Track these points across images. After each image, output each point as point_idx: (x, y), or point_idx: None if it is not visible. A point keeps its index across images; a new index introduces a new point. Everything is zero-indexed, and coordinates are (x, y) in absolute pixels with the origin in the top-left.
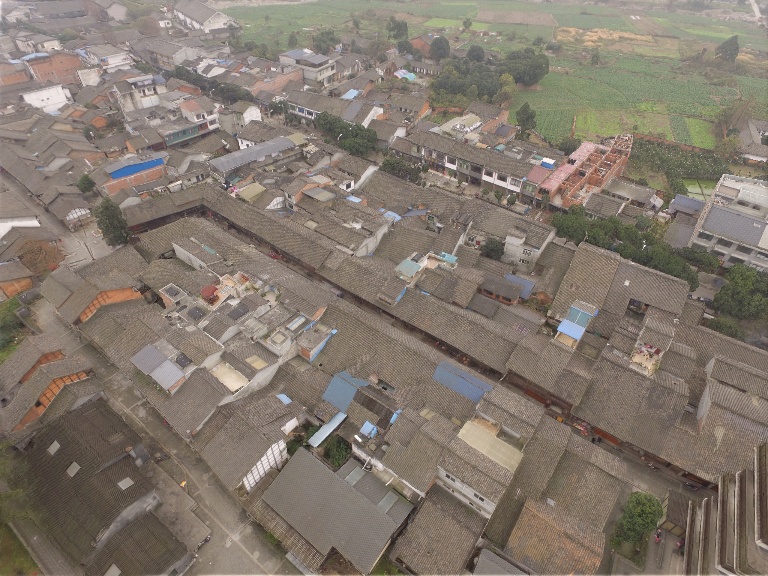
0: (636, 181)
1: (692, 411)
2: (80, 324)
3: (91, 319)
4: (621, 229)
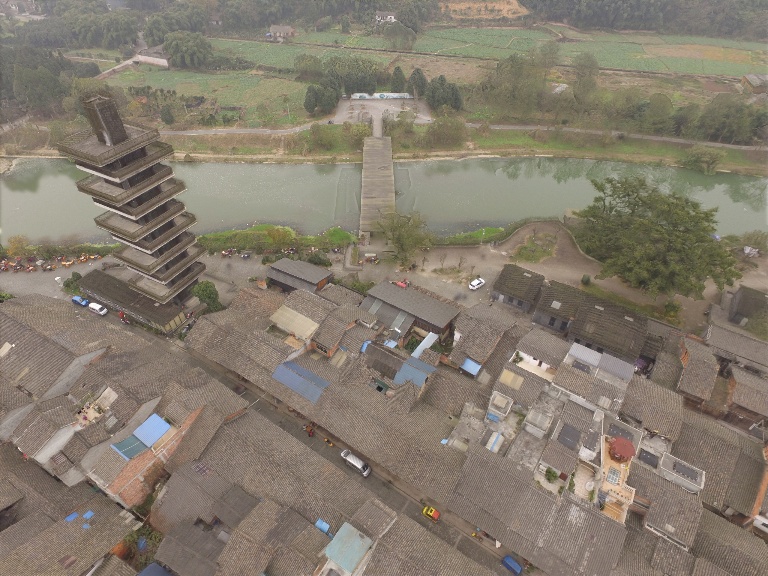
0: None
1: None
2: (764, 446)
3: (759, 451)
4: None
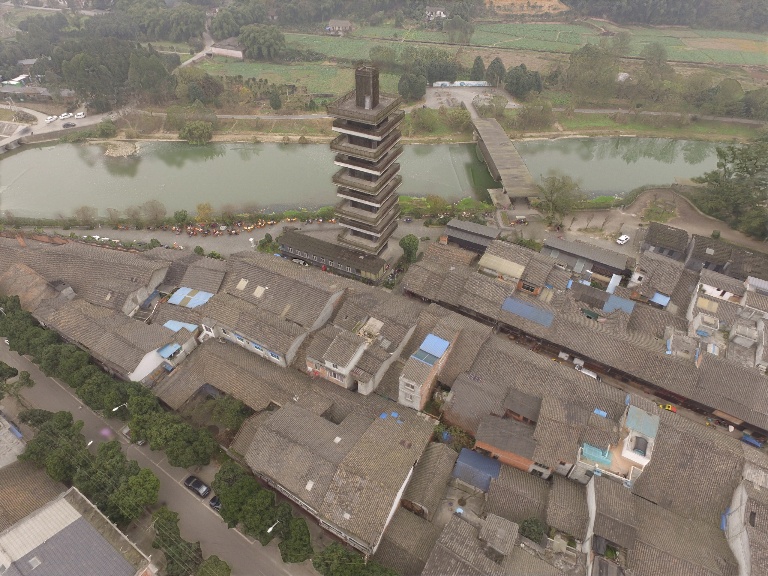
0: None
1: (330, 322)
2: None
3: None
4: None
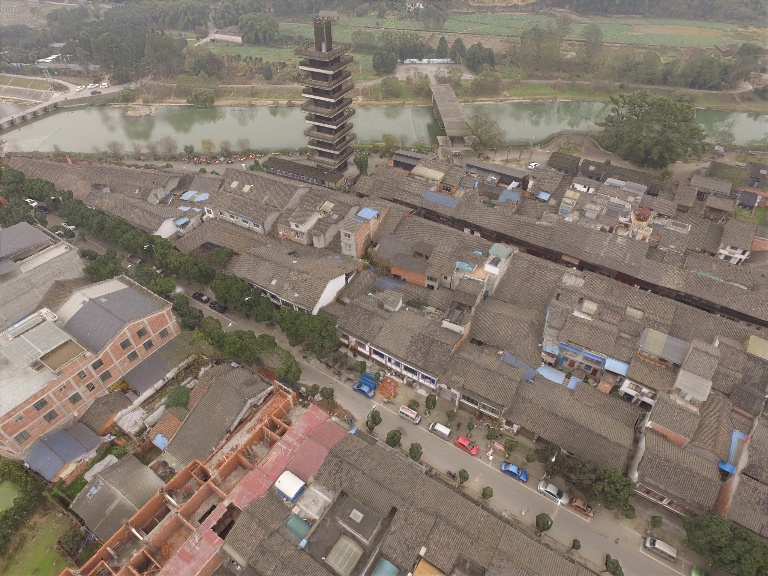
0: (75, 554)
1: None
2: None
3: None
4: (250, 334)
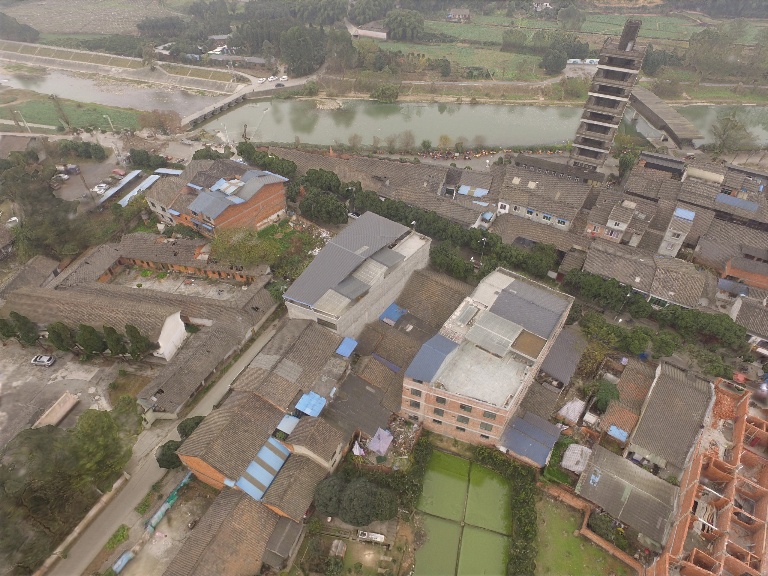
0: (612, 539)
1: None
2: None
3: None
4: None
